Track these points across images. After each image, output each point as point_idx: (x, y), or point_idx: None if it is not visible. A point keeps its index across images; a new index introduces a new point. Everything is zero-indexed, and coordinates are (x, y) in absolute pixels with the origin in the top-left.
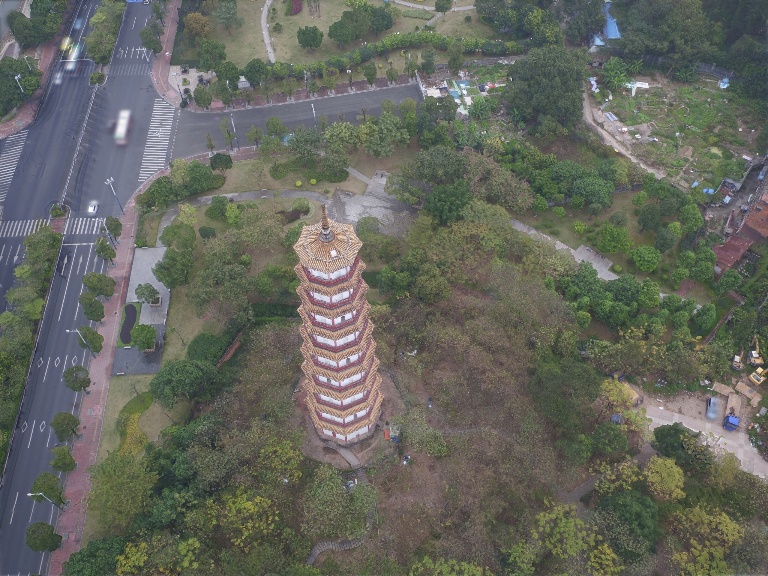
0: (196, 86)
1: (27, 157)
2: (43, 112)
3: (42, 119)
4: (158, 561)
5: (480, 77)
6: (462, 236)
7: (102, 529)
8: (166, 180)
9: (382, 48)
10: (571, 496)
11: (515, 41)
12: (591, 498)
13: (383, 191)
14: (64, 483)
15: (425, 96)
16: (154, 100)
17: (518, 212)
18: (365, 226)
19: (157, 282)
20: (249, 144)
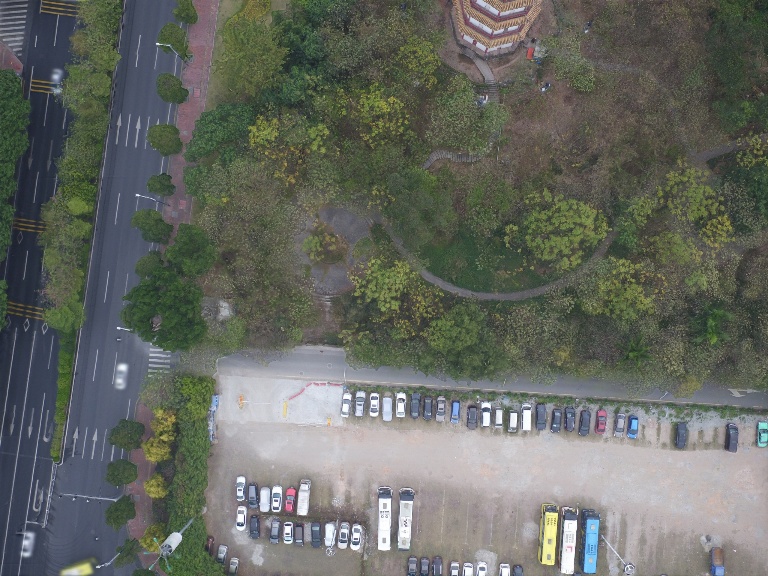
0: None
1: None
2: None
3: None
4: (289, 140)
5: None
6: None
7: (228, 92)
8: None
9: None
10: (699, 156)
11: None
12: (719, 163)
13: None
14: (186, 35)
15: None
16: None
17: None
18: None
19: None
20: None
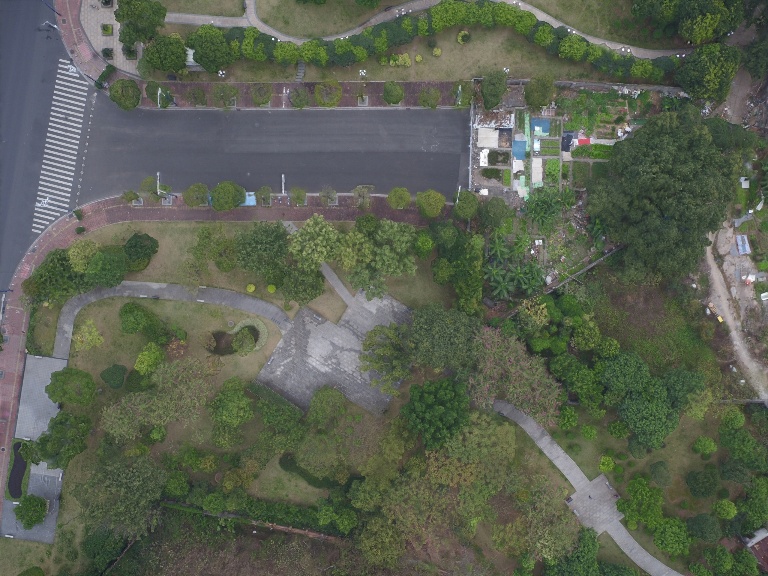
0: (121, 49)
1: None
2: None
3: None
4: None
5: (571, 116)
6: (437, 484)
7: None
8: (63, 262)
9: (426, 32)
10: None
11: (657, 40)
12: None
13: (365, 323)
14: None
15: (460, 195)
16: (57, 61)
17: (534, 418)
18: (319, 414)
19: (53, 414)
20: None
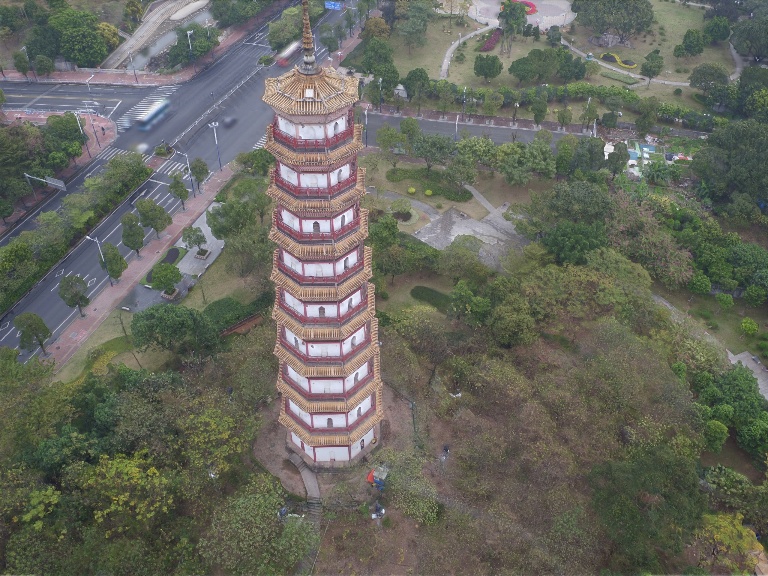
0: None
1: (166, 104)
2: (203, 75)
3: (199, 80)
4: None
5: (671, 146)
6: (576, 279)
7: None
8: None
9: (563, 92)
10: None
11: None
12: None
13: (504, 223)
14: None
15: (591, 136)
16: None
17: (667, 286)
18: (462, 242)
19: None
20: (379, 145)
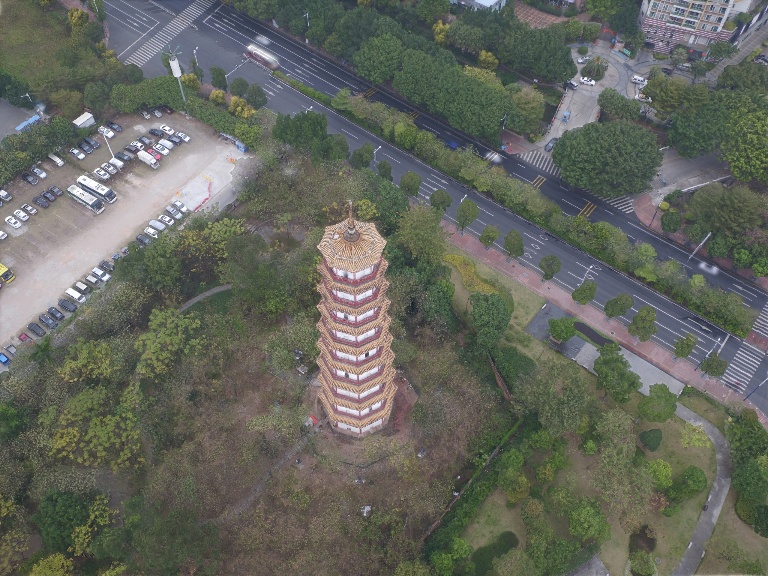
0: None
1: None
2: None
3: None
4: None
5: None
6: None
7: None
8: (767, 450)
9: None
10: None
11: None
12: None
13: None
14: None
15: None
16: None
17: None
18: None
19: None
20: None
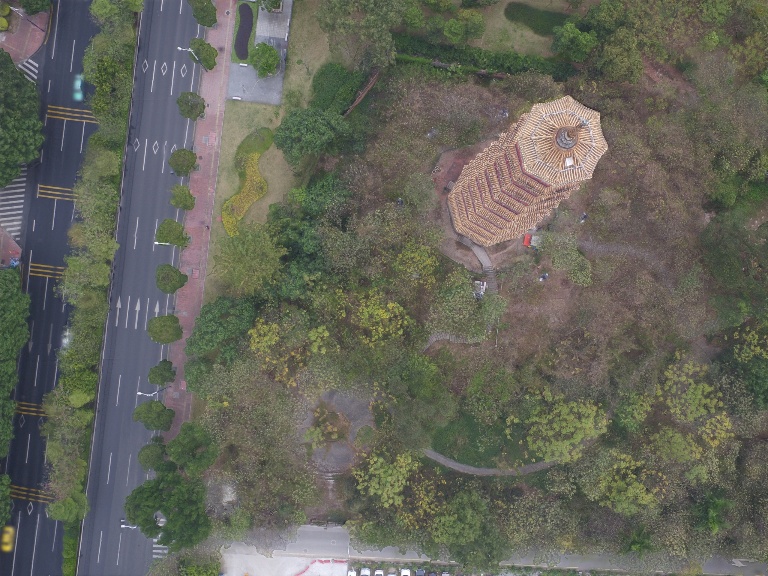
0: None
1: None
2: None
3: None
4: (290, 345)
5: None
6: None
7: None
8: None
9: None
10: None
11: None
12: (716, 337)
13: None
14: (183, 216)
15: None
16: None
17: None
18: None
19: None
20: None
